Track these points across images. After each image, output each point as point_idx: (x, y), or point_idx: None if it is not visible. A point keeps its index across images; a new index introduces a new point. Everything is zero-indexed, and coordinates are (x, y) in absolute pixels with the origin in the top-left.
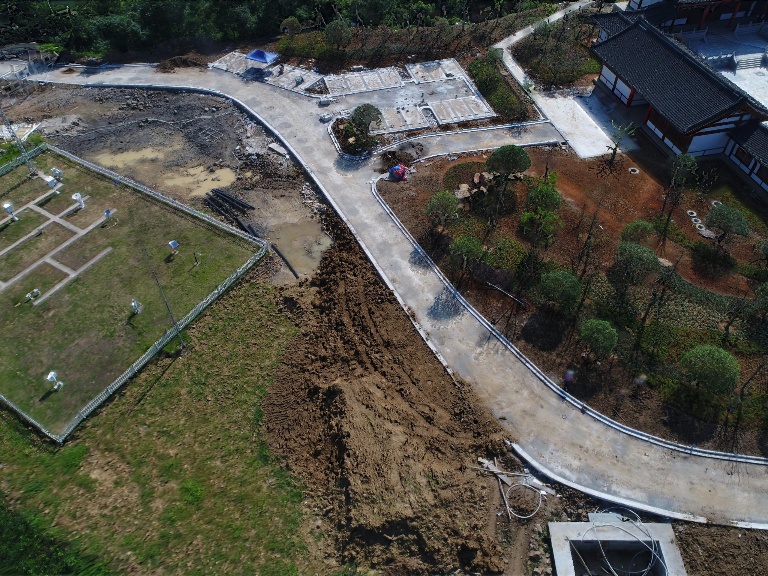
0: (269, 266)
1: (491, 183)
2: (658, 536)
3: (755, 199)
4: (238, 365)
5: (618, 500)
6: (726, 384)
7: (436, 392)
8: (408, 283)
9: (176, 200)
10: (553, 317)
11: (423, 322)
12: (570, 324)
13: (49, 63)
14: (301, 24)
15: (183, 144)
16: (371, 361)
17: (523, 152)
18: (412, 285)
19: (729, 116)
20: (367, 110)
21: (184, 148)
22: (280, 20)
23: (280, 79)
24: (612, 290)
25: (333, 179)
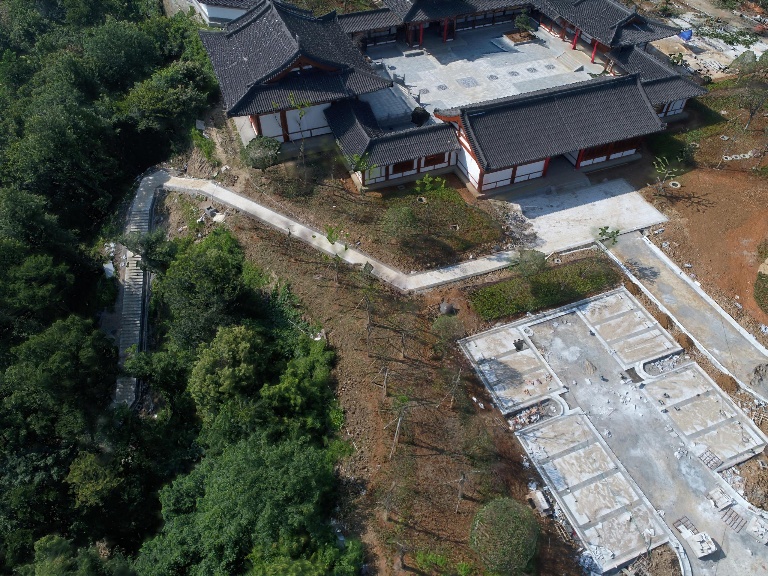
0: None
1: None
2: None
3: None
4: None
5: None
6: None
7: None
8: None
9: None
10: None
11: None
12: None
13: None
14: None
15: None
16: None
17: None
18: None
19: None
20: None
21: None
22: None
23: None
24: None
25: None
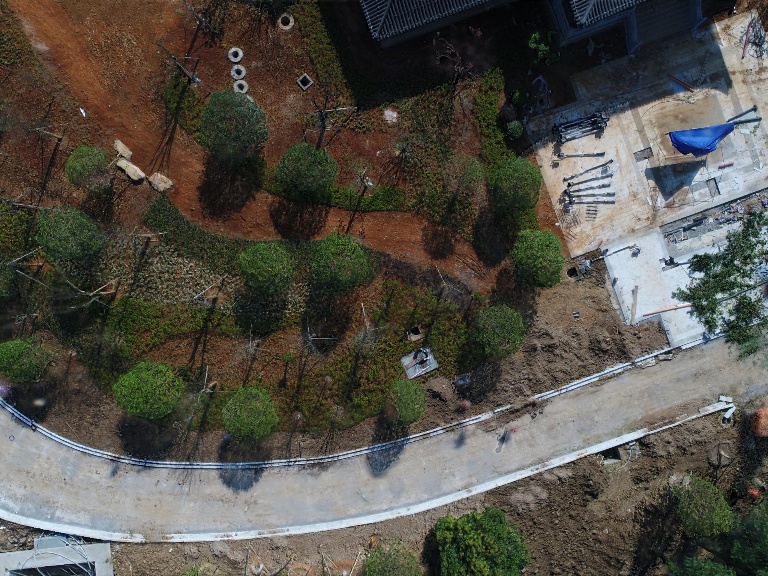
0: None
1: None
2: (94, 557)
3: None
4: None
5: (57, 530)
6: None
7: None
8: None
9: None
10: None
11: None
12: (21, 309)
13: None
14: None
15: None
16: None
17: None
18: None
19: None
20: None
21: None
22: None
23: None
24: None
25: None
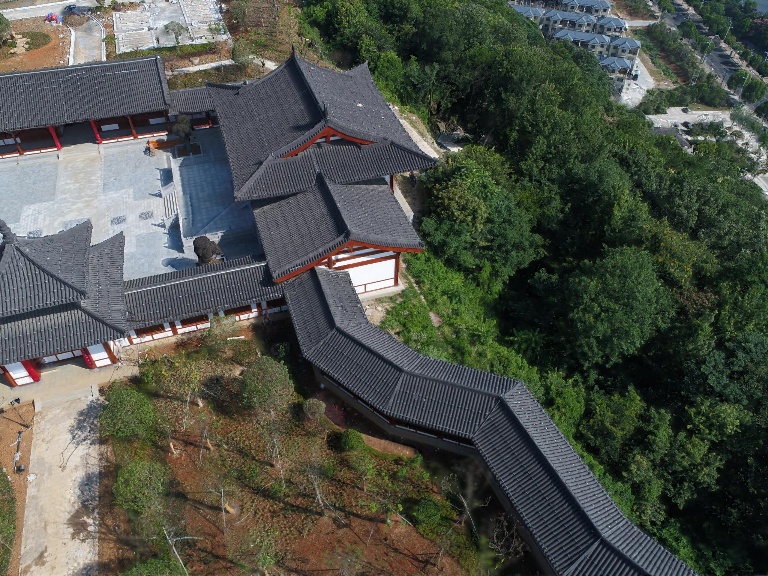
0: None
1: None
2: None
3: None
4: None
5: None
6: None
7: None
8: None
9: None
10: None
11: None
12: None
13: (622, 55)
14: None
15: None
16: None
17: None
18: None
19: None
20: None
21: None
22: None
23: None
24: None
25: None
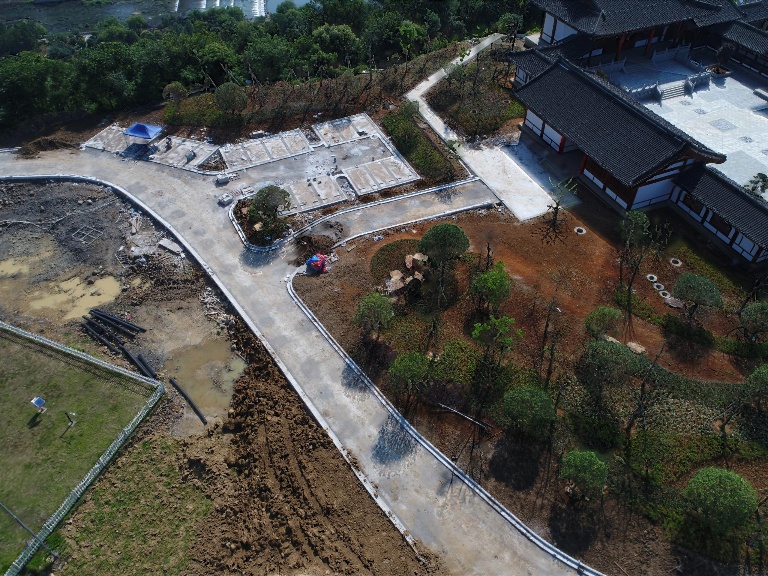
0: (168, 412)
1: (426, 266)
2: None
3: (713, 251)
4: (133, 573)
5: None
6: (744, 518)
7: (396, 575)
8: (344, 415)
9: (41, 336)
10: (524, 441)
11: (368, 470)
12: (545, 448)
13: None
14: (187, 89)
15: (53, 250)
16: (308, 540)
17: (459, 232)
18: (349, 417)
19: (673, 162)
20: (271, 194)
21: (54, 255)
22: (163, 84)
23: (168, 155)
24: (585, 394)
25: (240, 280)
